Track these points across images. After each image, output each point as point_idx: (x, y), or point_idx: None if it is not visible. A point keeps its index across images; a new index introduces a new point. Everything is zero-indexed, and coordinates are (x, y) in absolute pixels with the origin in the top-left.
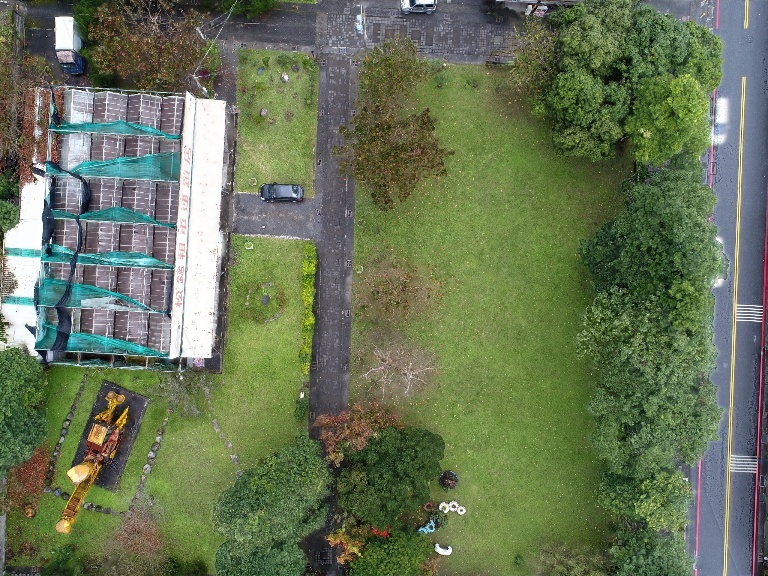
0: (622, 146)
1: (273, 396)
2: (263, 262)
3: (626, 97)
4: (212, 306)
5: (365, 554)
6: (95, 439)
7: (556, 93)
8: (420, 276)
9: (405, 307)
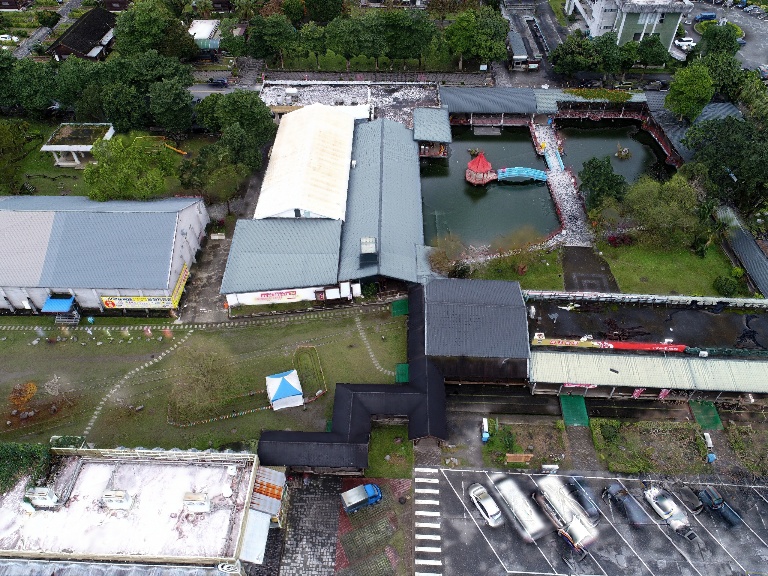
0: None
1: None
2: None
3: None
4: None
5: None
6: None
7: None
8: None
9: None
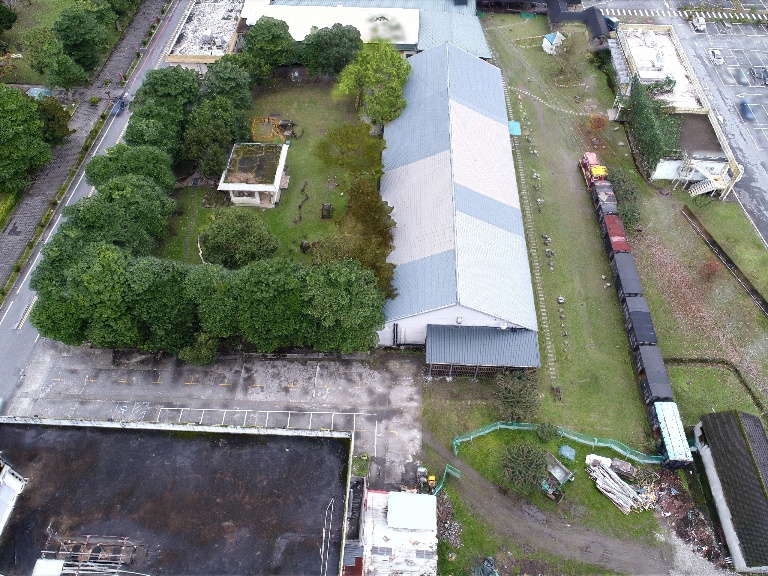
0: None
1: None
2: None
3: None
4: None
5: None
6: None
7: None
8: (46, 3)
9: None
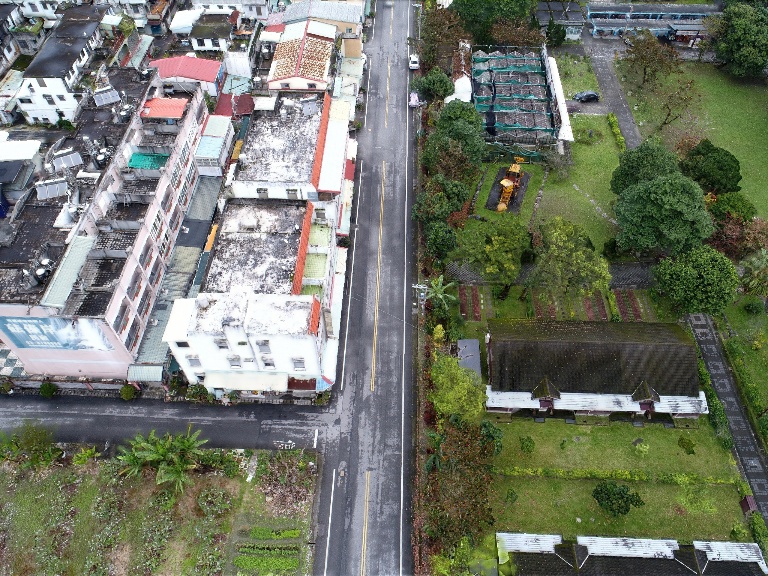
0: (765, 83)
1: (608, 174)
2: (583, 123)
3: (767, 29)
4: (569, 122)
5: (717, 197)
6: (514, 169)
7: (731, 34)
8: (678, 127)
9: (689, 103)
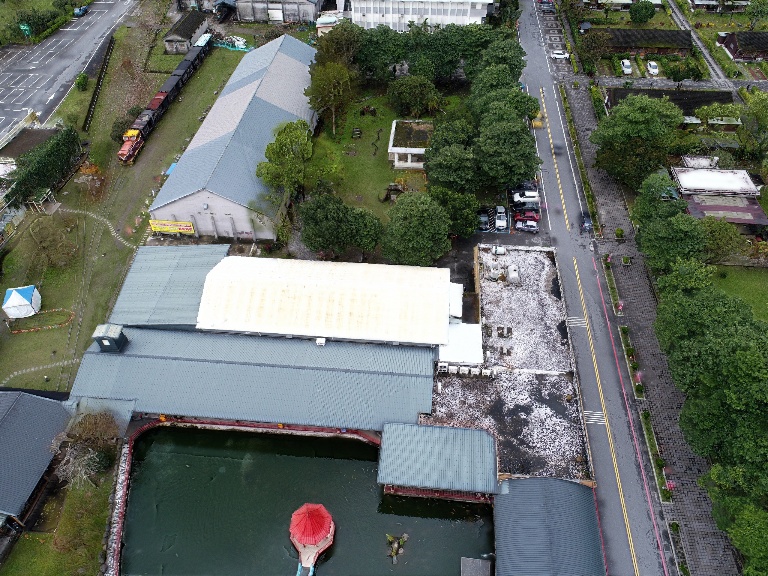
0: None
1: None
2: None
3: None
4: None
5: None
6: None
7: None
8: None
9: None
